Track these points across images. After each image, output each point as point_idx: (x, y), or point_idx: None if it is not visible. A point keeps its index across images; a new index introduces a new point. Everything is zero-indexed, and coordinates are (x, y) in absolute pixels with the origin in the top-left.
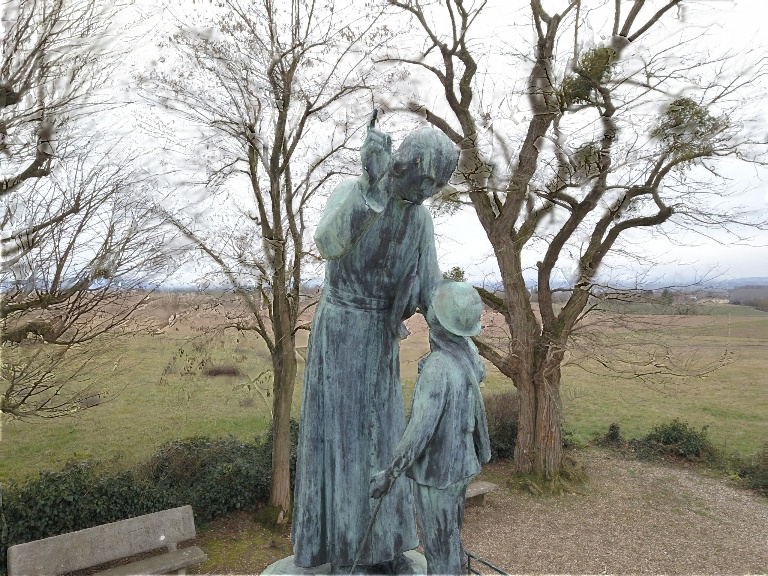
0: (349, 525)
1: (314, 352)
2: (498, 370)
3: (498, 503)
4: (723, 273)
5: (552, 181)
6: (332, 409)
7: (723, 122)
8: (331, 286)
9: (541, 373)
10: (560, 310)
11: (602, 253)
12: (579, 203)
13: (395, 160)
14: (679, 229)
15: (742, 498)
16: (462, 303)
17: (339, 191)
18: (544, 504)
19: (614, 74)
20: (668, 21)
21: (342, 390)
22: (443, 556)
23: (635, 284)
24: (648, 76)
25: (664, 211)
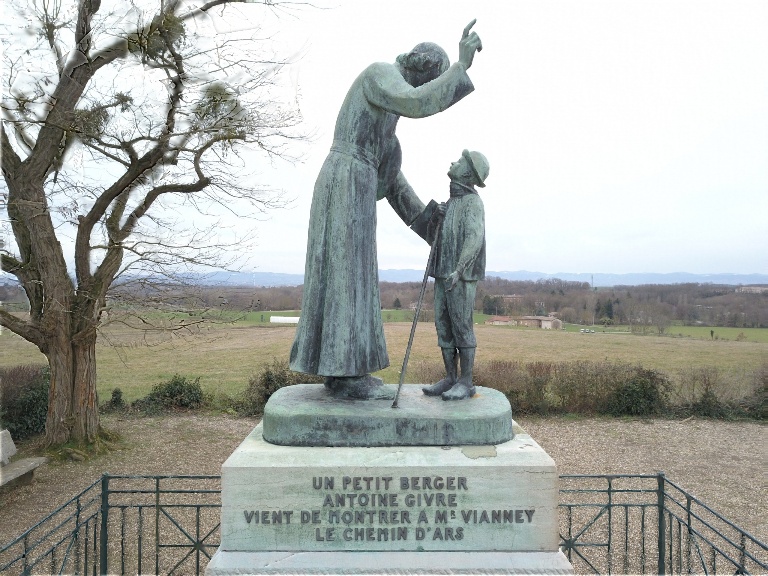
0: (367, 342)
1: (349, 198)
2: (17, 337)
3: (45, 478)
4: (254, 236)
5: (128, 130)
6: (355, 248)
7: (297, 111)
8: (358, 145)
9: (86, 332)
10: (95, 269)
11: (140, 214)
12: (138, 159)
13: (428, 58)
14: (208, 199)
15: (246, 423)
16: (487, 164)
17: (393, 68)
18: (97, 465)
19: (183, 45)
20: (213, 15)
21: (364, 232)
22: (472, 329)
23: (190, 241)
24: (219, 57)
25: (203, 180)
